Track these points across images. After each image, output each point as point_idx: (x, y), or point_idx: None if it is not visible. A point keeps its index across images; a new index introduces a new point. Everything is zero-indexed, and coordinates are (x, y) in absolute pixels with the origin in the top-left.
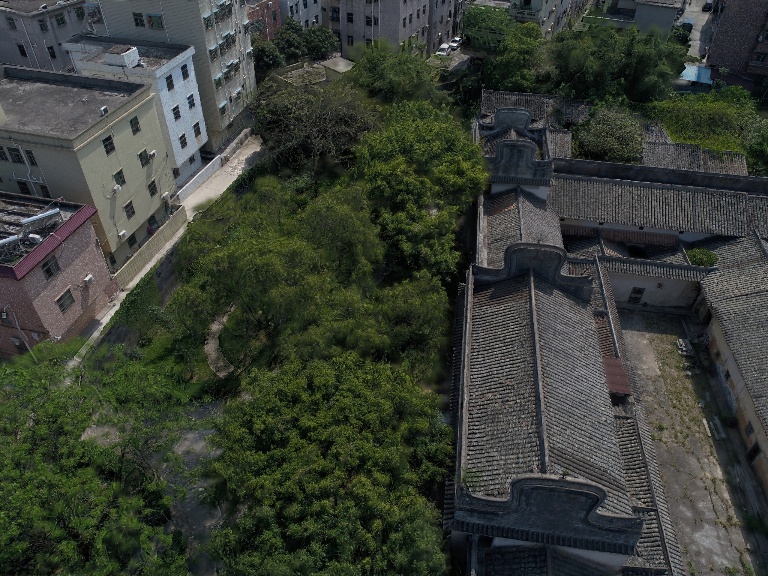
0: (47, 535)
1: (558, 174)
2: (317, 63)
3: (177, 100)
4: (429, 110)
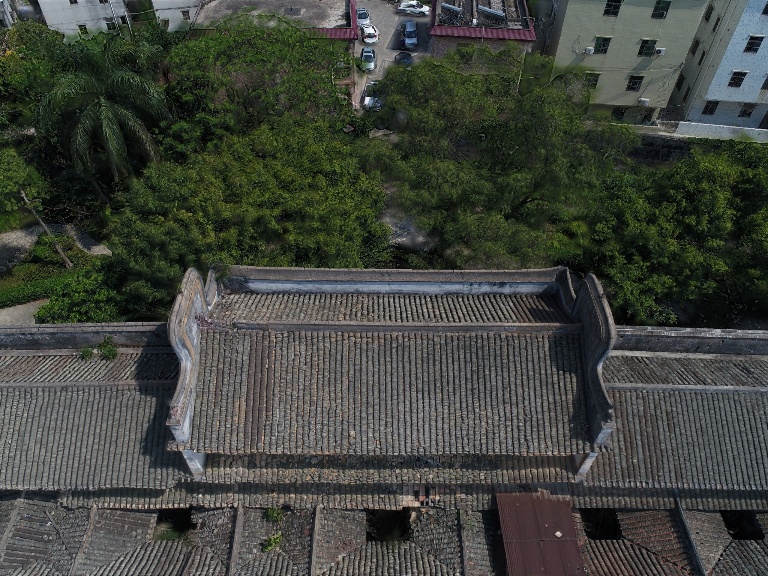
0: (185, 79)
1: None
2: None
3: (767, 31)
4: None
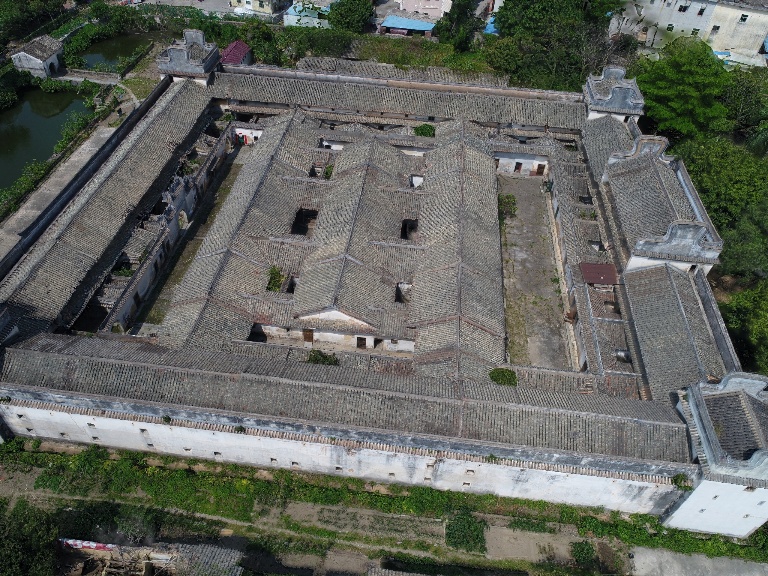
0: None
1: (677, 423)
2: None
3: None
4: None
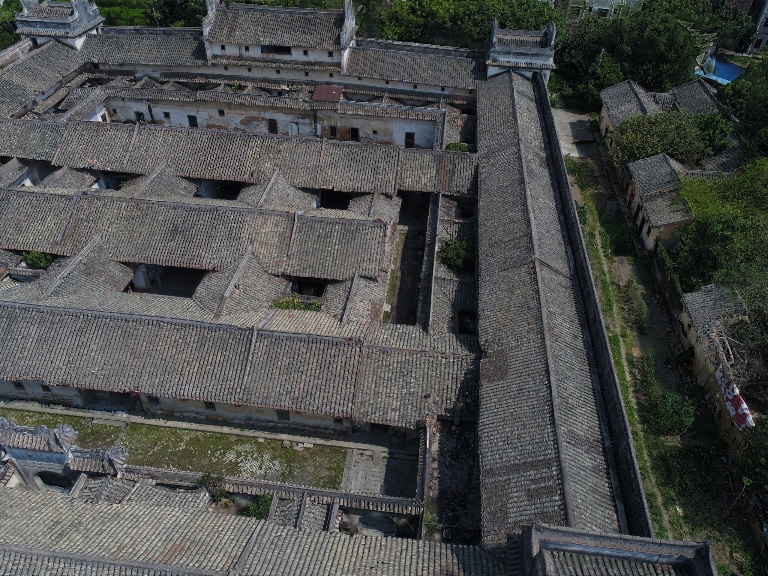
0: None
1: (511, 71)
2: (703, 33)
3: None
4: (529, 3)
